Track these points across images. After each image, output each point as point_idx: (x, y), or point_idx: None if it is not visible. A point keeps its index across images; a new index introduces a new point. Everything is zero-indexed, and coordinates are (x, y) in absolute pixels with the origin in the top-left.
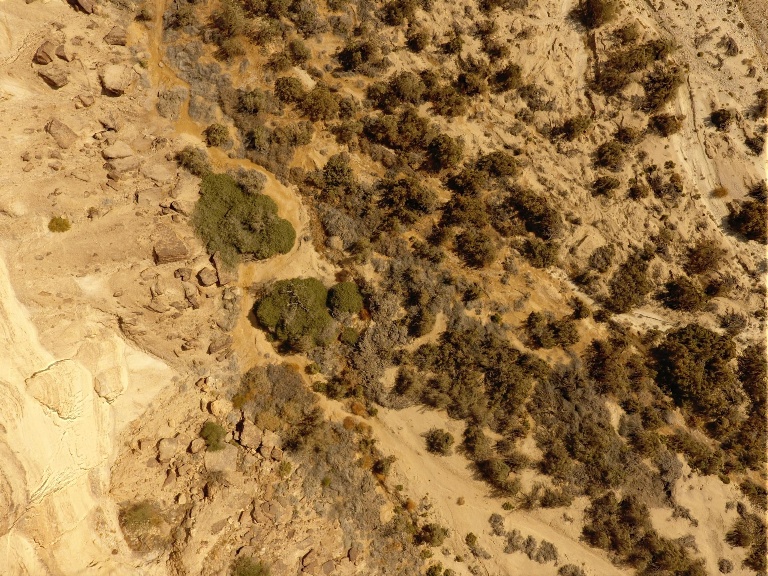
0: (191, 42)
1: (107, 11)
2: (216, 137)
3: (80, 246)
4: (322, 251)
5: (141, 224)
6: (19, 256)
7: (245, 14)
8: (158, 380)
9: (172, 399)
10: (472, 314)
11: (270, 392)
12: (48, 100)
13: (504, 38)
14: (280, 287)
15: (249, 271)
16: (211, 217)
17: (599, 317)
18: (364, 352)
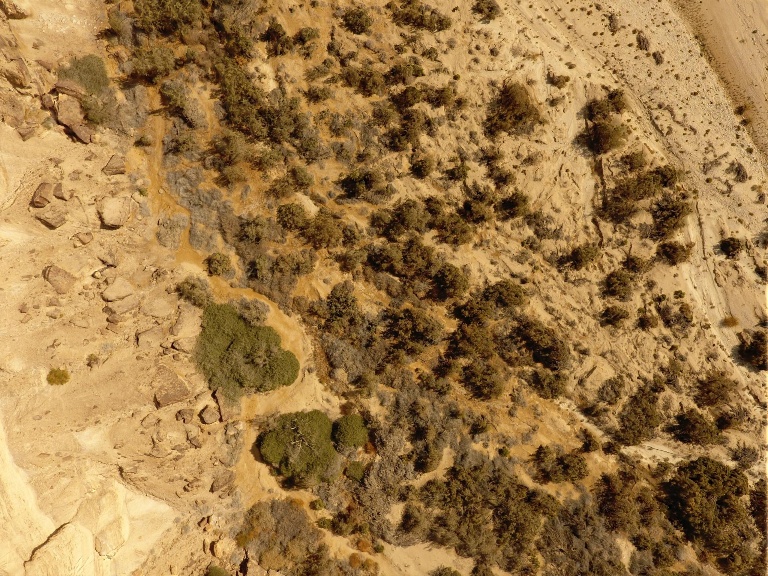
0: (191, 168)
1: (105, 139)
2: (217, 268)
3: (79, 400)
4: (326, 382)
5: (142, 369)
6: (17, 416)
7: (246, 139)
8: (160, 524)
9: (174, 542)
10: (479, 448)
11: (274, 529)
12: (46, 241)
13: (510, 164)
14: (284, 422)
15: (252, 403)
16: (213, 352)
17: (609, 450)
18: (370, 488)
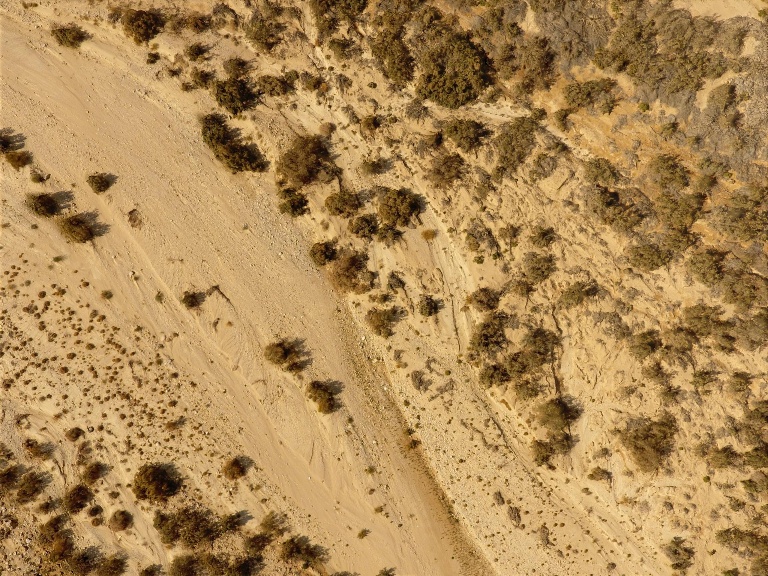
0: None
1: None
2: None
3: None
4: None
5: None
6: None
7: None
8: None
9: None
10: (669, 110)
11: None
12: None
13: (648, 388)
14: None
15: None
16: None
17: (543, 113)
18: None
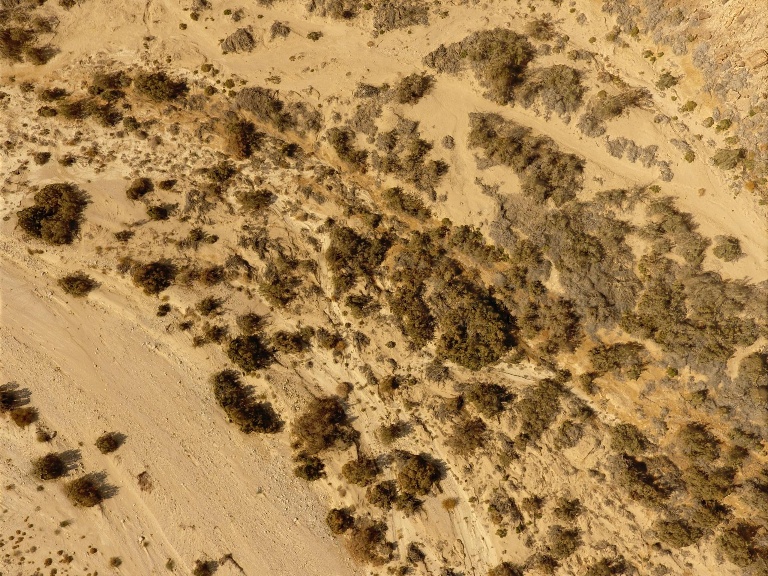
0: None
1: None
2: None
3: None
4: None
5: None
6: None
7: None
8: None
9: None
10: (699, 377)
11: None
12: None
13: None
14: None
15: None
16: None
17: (568, 376)
18: None
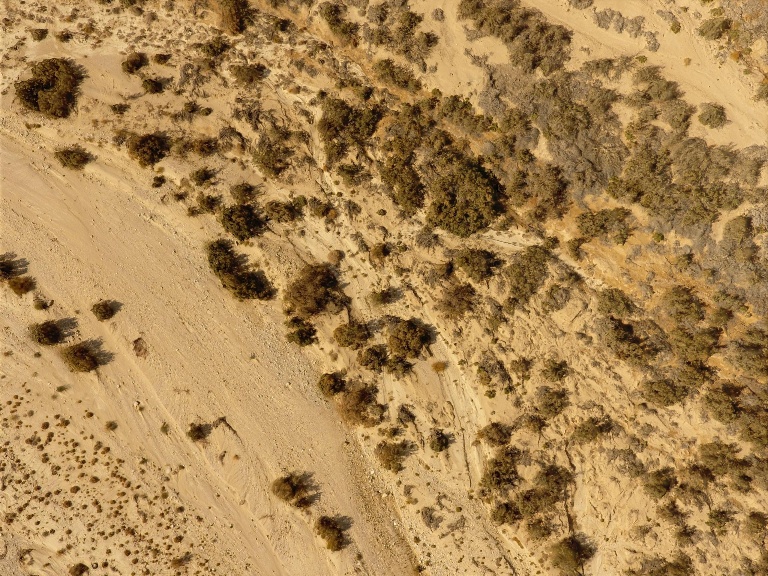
0: None
1: None
2: None
3: None
4: None
5: None
6: None
7: None
8: None
9: None
10: (684, 241)
11: None
12: None
13: (663, 528)
14: None
15: None
16: None
17: (556, 242)
18: None
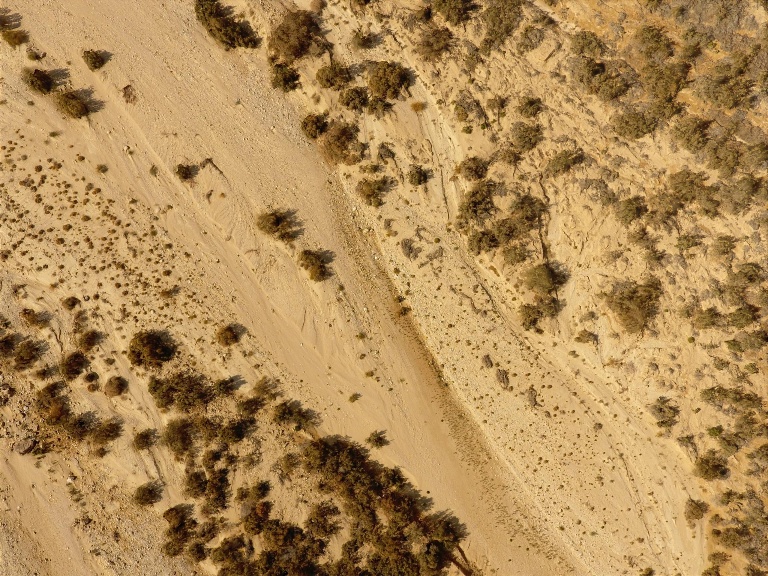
0: None
1: None
2: None
3: None
4: None
5: None
6: None
7: None
8: None
9: None
10: None
11: None
12: None
13: (634, 252)
14: None
15: None
16: None
17: None
18: None
